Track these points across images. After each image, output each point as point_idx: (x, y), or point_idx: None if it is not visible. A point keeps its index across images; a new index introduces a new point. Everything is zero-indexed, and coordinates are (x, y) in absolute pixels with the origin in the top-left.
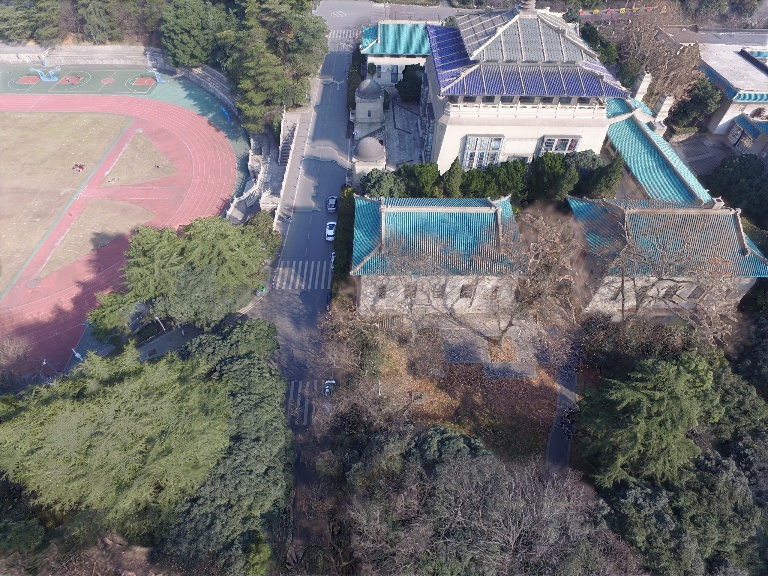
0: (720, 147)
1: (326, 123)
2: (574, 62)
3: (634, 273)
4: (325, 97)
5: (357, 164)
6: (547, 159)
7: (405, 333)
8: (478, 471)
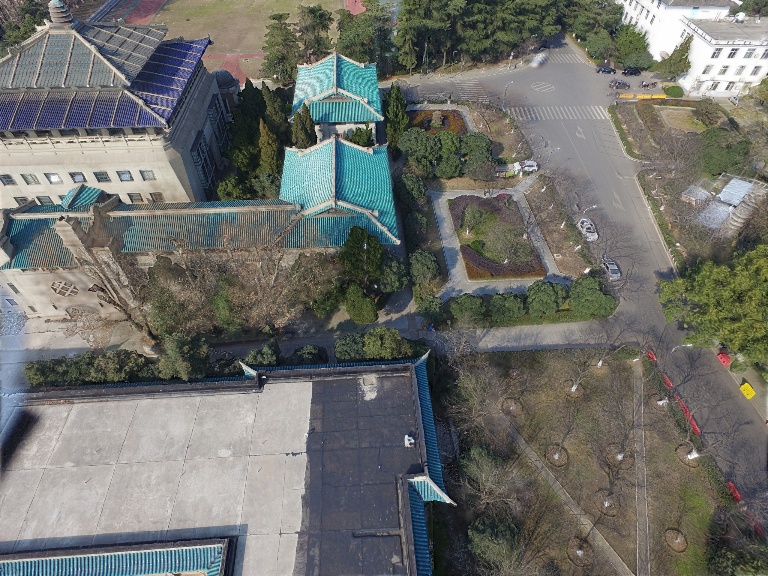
0: None
1: None
2: None
3: None
4: None
5: None
6: None
7: None
8: None
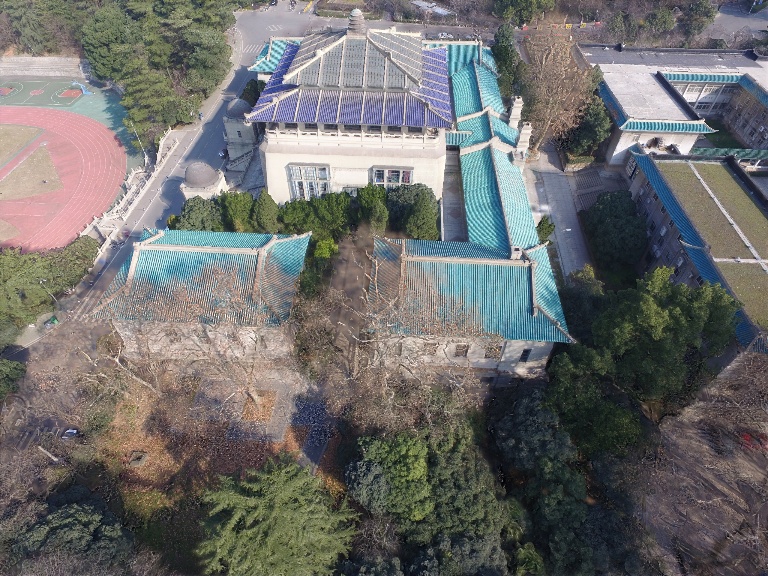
0: (616, 179)
1: (208, 142)
2: (401, 88)
3: (399, 330)
4: (219, 114)
5: (184, 190)
6: (363, 193)
7: (163, 381)
8: (83, 568)
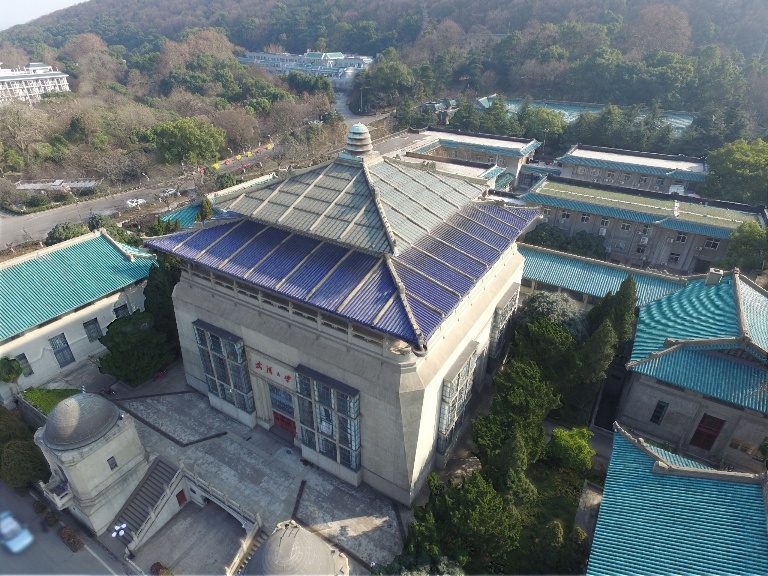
0: None
1: None
2: None
3: None
4: None
5: None
6: (556, 335)
7: None
8: None
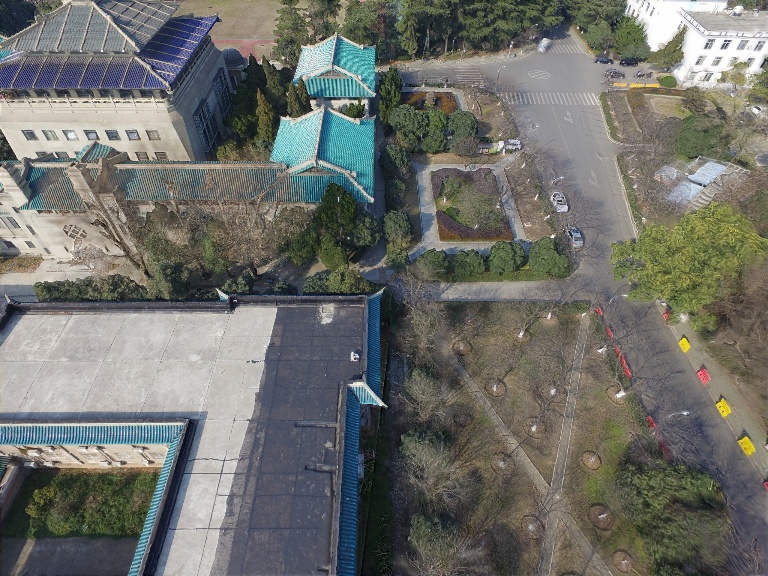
0: None
1: None
2: None
3: None
4: None
5: None
6: None
7: None
8: None
